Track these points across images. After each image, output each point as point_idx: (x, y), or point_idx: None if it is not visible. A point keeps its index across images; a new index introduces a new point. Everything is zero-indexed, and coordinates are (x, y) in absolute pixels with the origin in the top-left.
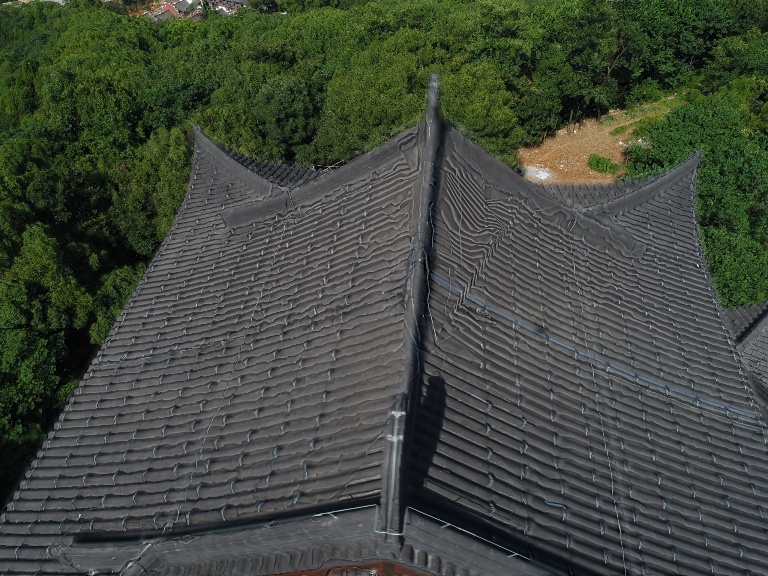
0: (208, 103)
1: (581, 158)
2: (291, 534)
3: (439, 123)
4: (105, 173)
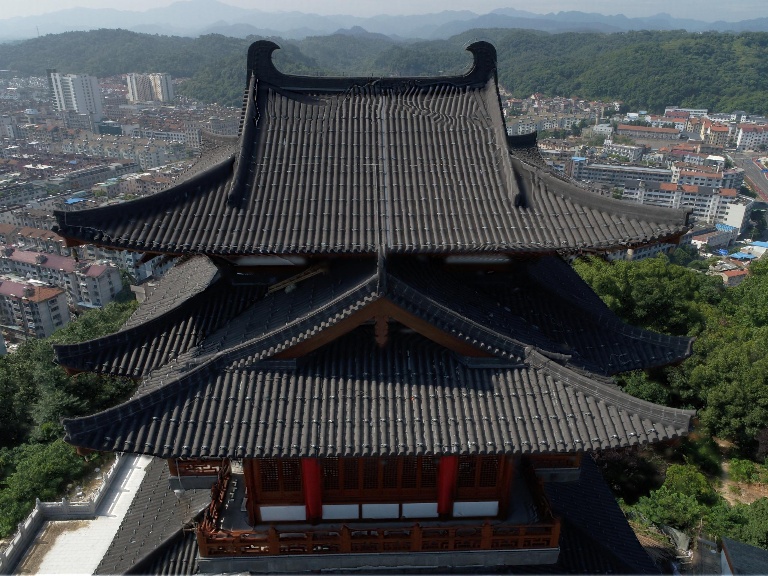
0: None
1: None
2: None
3: (481, 71)
4: (707, 317)
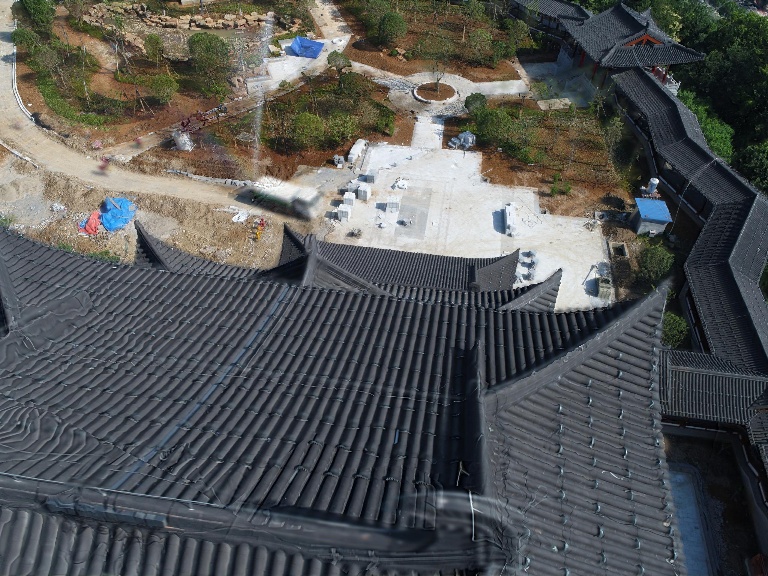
0: None
1: None
2: None
3: None
4: None
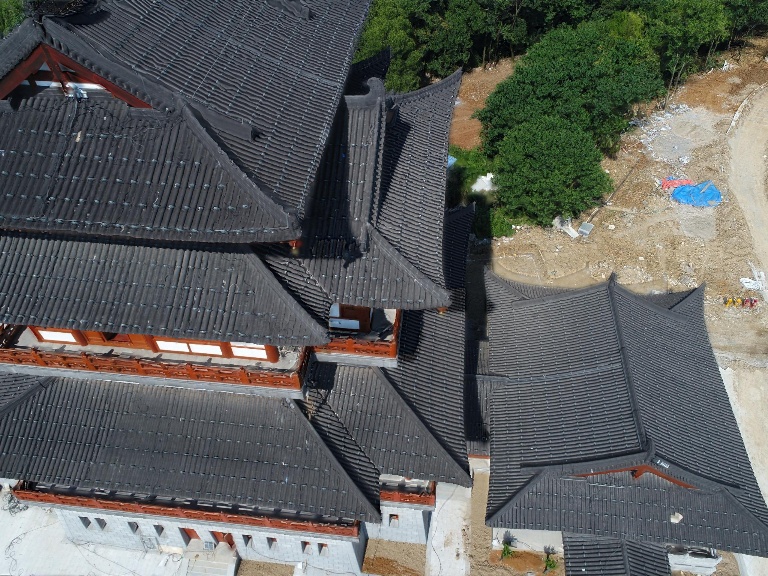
0: None
1: (491, 90)
2: (7, 45)
3: None
4: None
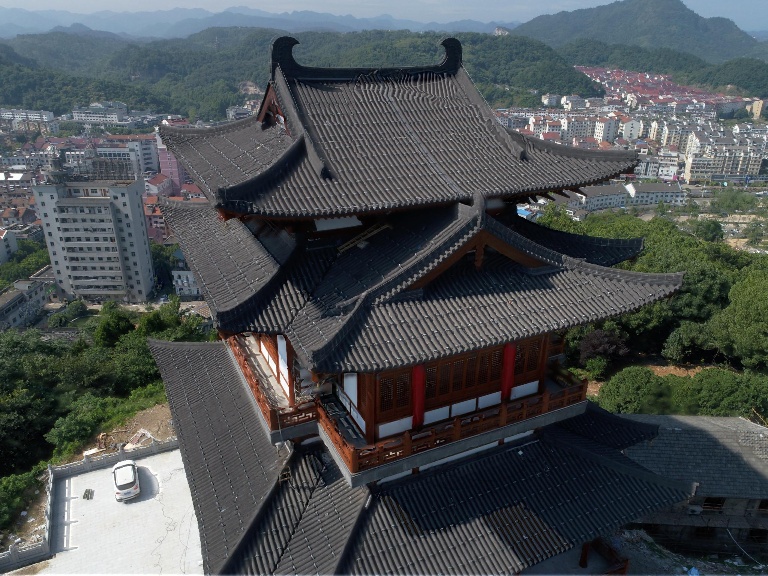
0: (635, 262)
1: None
2: None
3: (452, 61)
4: None
